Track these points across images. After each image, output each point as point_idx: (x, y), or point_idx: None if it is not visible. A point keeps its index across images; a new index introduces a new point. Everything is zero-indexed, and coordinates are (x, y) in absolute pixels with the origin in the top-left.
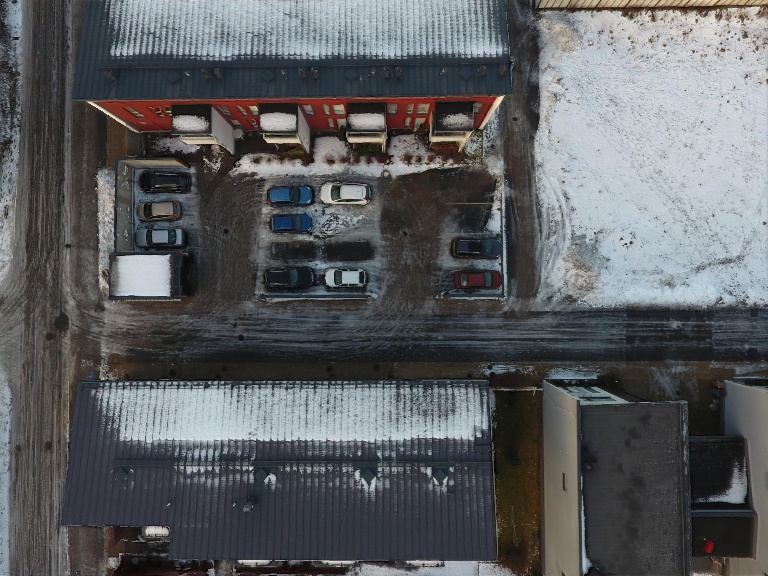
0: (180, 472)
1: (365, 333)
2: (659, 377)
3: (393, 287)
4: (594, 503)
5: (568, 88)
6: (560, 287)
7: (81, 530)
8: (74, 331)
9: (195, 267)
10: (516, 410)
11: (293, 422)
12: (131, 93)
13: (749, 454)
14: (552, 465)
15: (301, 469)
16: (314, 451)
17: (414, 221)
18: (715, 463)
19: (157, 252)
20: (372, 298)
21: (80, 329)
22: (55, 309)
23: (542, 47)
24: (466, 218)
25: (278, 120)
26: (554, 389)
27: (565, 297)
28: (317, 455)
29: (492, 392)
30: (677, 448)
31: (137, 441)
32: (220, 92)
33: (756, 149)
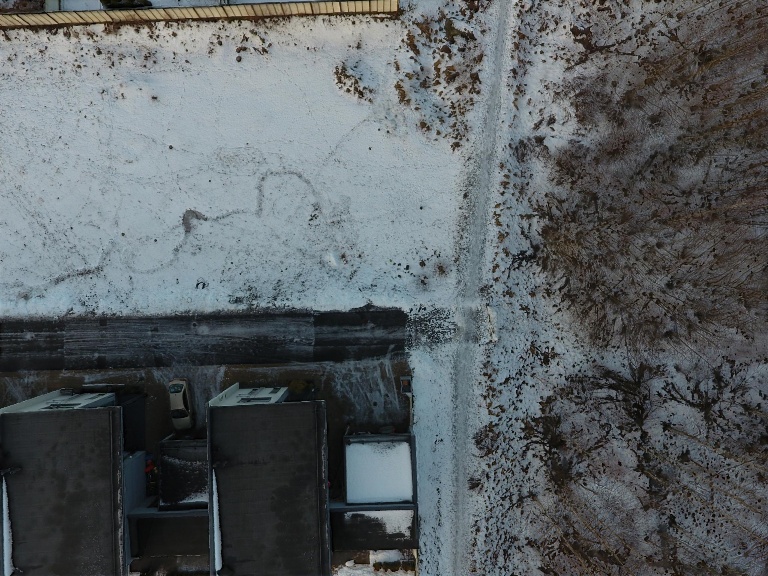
0: None
1: None
2: (12, 387)
3: None
4: None
5: None
6: None
7: None
8: None
9: None
10: None
11: None
12: None
13: None
14: None
15: None
16: None
17: None
18: None
19: None
20: None
21: None
22: None
23: None
24: None
25: None
26: None
27: None
28: None
29: None
30: None
31: None
32: None
33: (112, 162)
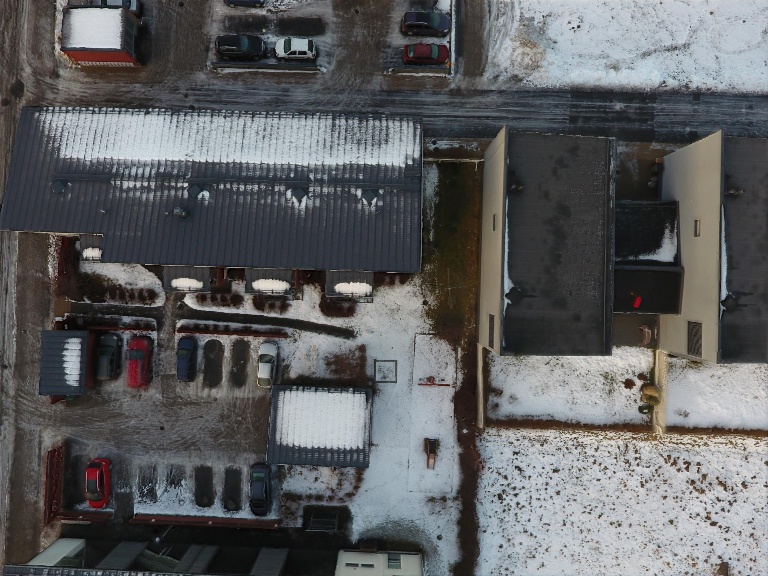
0: (116, 187)
1: (313, 106)
2: None
3: (342, 62)
4: (518, 226)
5: None
6: (506, 67)
7: (28, 290)
8: (29, 97)
9: (149, 37)
10: (456, 177)
11: (229, 146)
12: None
13: (680, 214)
14: (487, 224)
15: (234, 187)
16: (248, 172)
17: None
18: (647, 224)
19: (109, 6)
20: (321, 72)
21: (35, 95)
22: (11, 76)
23: None
24: None
25: None
26: (491, 143)
27: (511, 77)
28: (251, 175)
29: (435, 167)
30: (603, 181)
31: (76, 158)
32: None
33: None
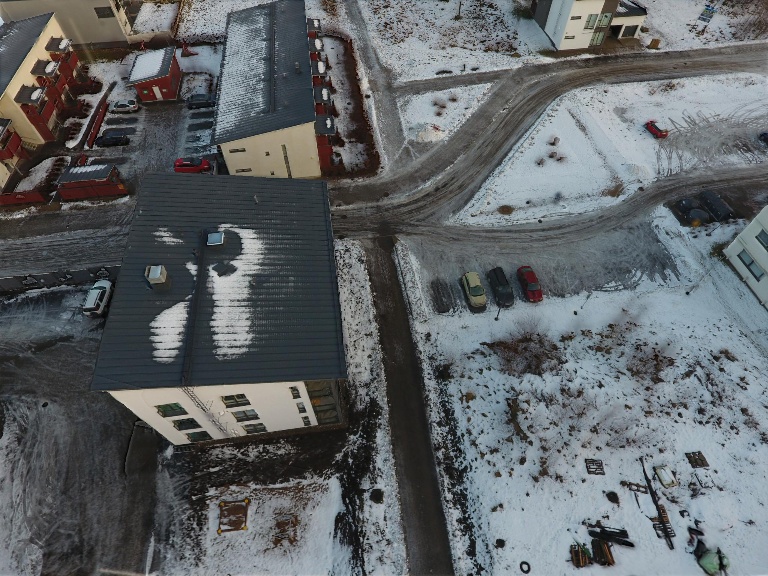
0: None
1: None
2: None
3: None
4: None
5: None
6: None
7: (33, 228)
8: None
9: None
10: None
11: None
12: None
13: None
14: None
15: None
16: None
17: None
18: None
19: None
20: None
21: None
22: None
23: None
24: None
25: None
26: None
27: None
28: None
29: None
30: None
31: None
32: None
33: None
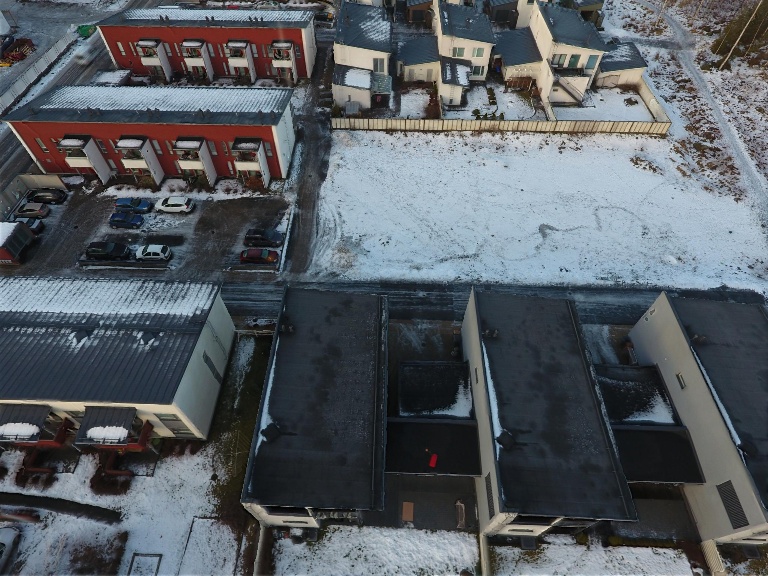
0: None
1: None
2: (406, 331)
3: (191, 263)
4: (286, 364)
5: (348, 163)
6: (327, 267)
7: None
8: None
9: (38, 246)
10: (265, 345)
11: (39, 300)
12: (39, 119)
13: (470, 370)
14: None
15: (23, 330)
16: (44, 319)
17: (222, 225)
18: (440, 380)
19: (10, 221)
20: (170, 269)
21: None
22: None
23: (334, 145)
24: (262, 224)
25: (130, 142)
26: None
27: (330, 273)
28: (44, 321)
29: (253, 341)
30: (375, 328)
31: None
32: (95, 119)
33: (480, 195)
